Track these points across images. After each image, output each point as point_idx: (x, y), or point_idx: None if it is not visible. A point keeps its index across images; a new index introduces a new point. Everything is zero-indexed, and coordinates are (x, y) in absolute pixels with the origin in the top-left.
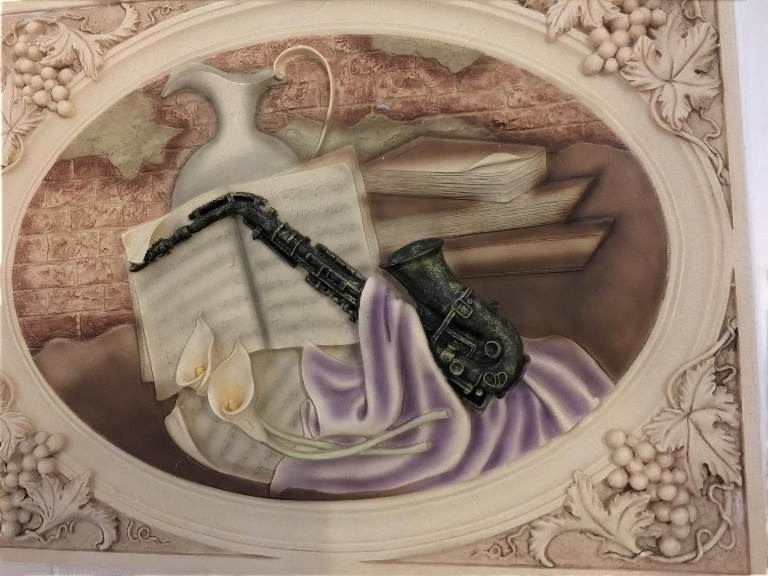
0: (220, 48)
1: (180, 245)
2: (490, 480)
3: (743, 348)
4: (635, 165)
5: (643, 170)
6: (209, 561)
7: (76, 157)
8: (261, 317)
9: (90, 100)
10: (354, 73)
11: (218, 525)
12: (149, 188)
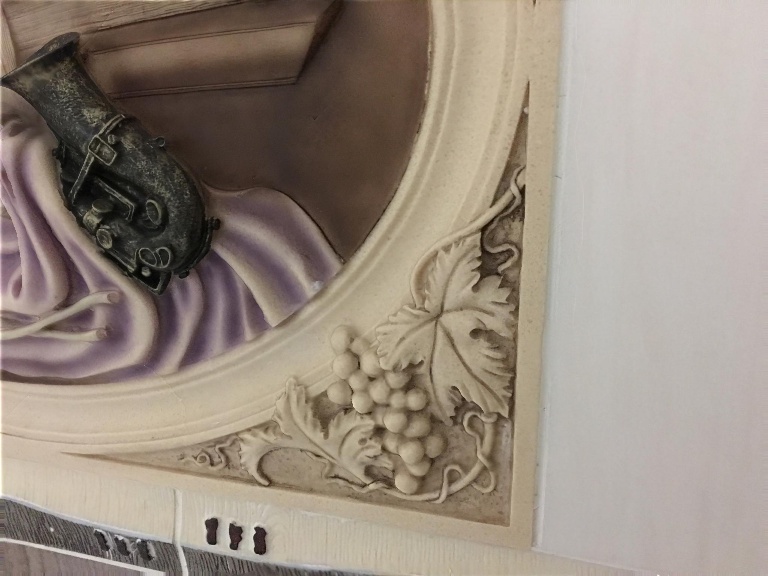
0: None
1: None
2: (194, 376)
3: (529, 220)
4: None
5: None
6: None
7: None
8: None
9: None
10: None
11: None
12: None
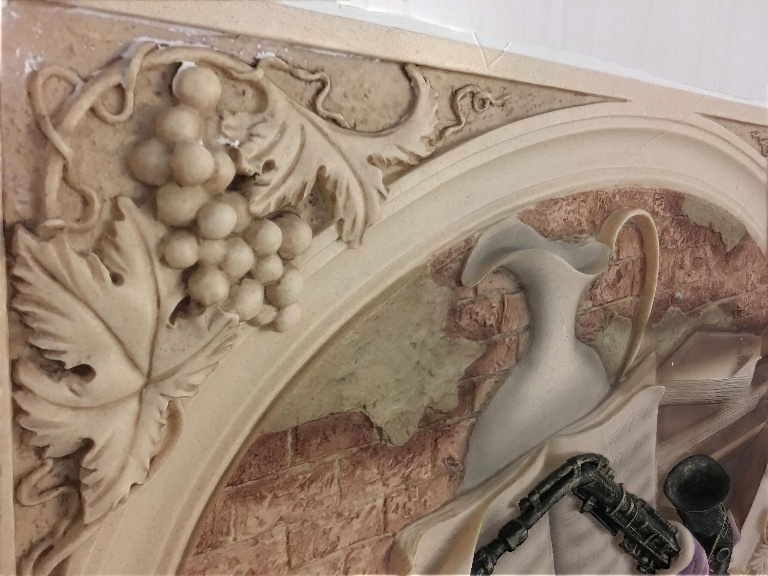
0: (545, 194)
1: None
2: None
3: None
4: None
5: None
6: None
7: (305, 422)
8: None
9: (323, 285)
10: (663, 247)
11: None
12: (429, 454)
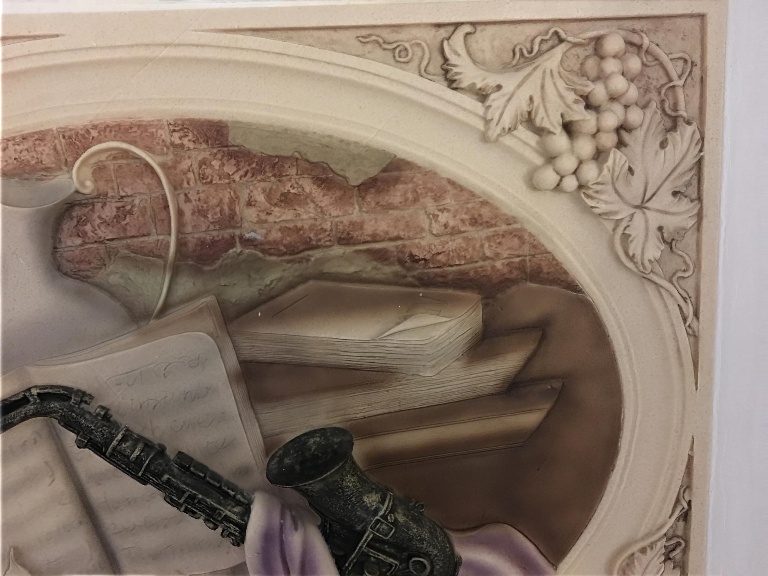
0: None
1: None
2: None
3: (695, 523)
4: (590, 312)
5: (599, 318)
6: None
7: None
8: (105, 540)
9: None
10: (204, 182)
11: None
12: None
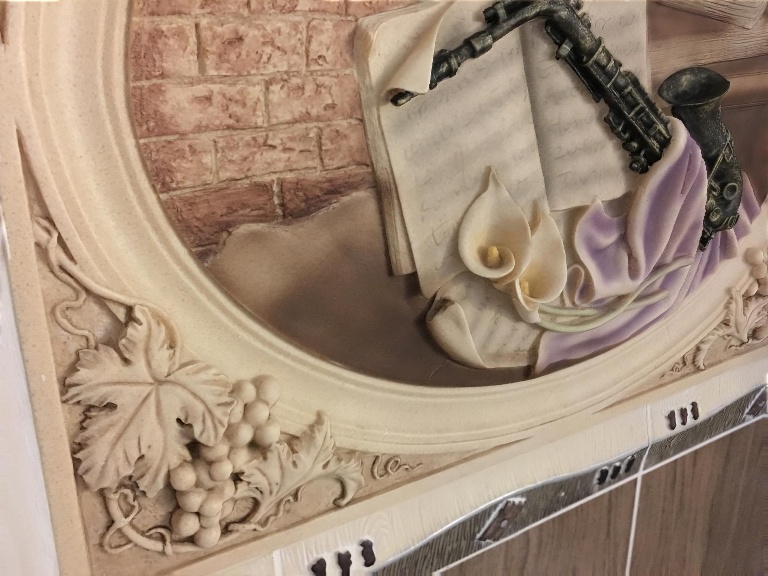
0: None
1: (465, 62)
2: None
3: None
4: None
5: None
6: (470, 467)
7: None
8: None
9: None
10: None
11: (473, 426)
12: None
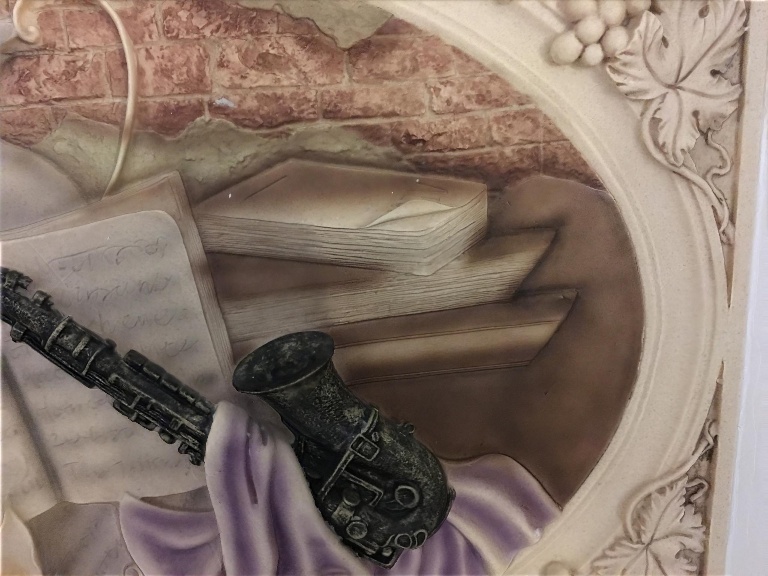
0: None
1: None
2: None
3: (721, 461)
4: (611, 212)
5: (621, 220)
6: None
7: None
8: (45, 454)
9: None
10: (169, 36)
11: None
12: None
